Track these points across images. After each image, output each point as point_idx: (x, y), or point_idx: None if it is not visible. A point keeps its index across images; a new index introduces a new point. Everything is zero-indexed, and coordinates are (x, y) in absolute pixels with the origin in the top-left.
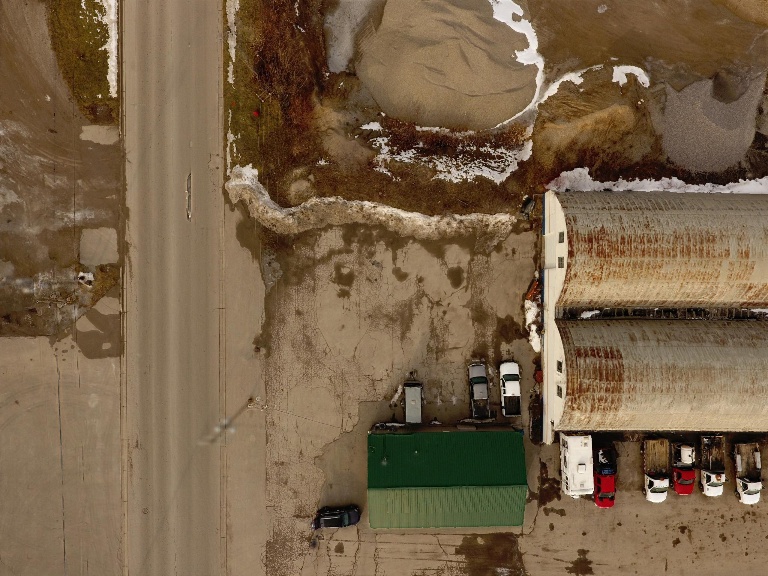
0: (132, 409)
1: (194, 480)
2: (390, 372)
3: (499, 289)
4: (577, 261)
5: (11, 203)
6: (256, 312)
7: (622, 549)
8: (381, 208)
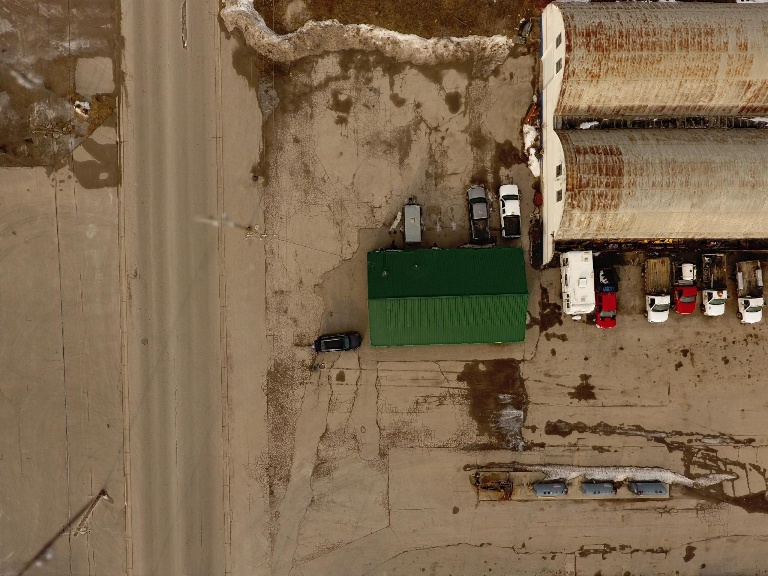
0: (130, 239)
1: (194, 310)
2: (389, 199)
3: (497, 114)
4: (575, 56)
5: (5, 33)
6: (253, 140)
7: (624, 373)
8: (378, 31)
